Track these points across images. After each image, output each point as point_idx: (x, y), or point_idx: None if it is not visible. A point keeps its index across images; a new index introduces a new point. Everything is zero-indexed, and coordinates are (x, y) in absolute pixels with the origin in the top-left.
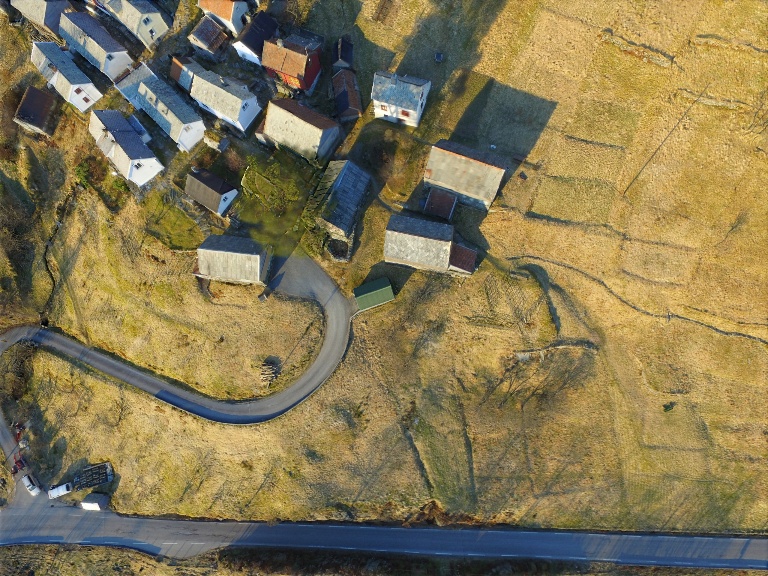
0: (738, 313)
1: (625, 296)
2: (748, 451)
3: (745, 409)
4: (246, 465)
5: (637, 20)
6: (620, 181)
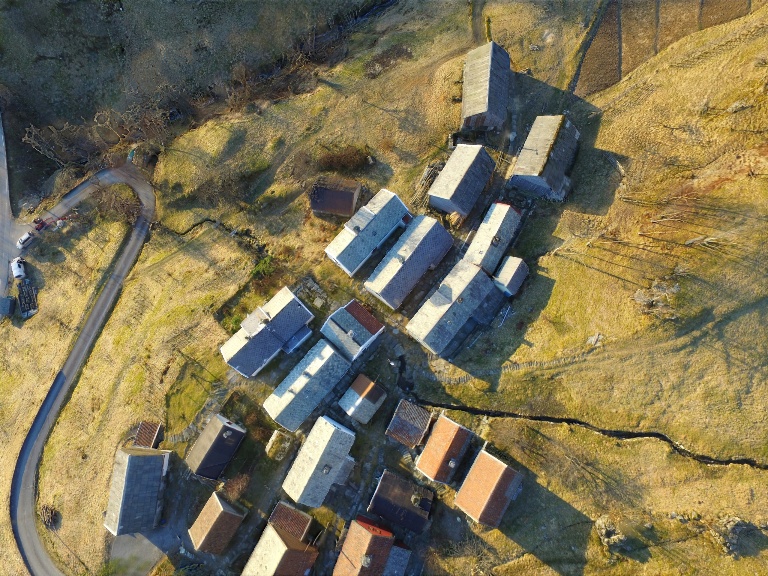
0: None
1: None
2: None
3: None
4: None
5: None
6: None
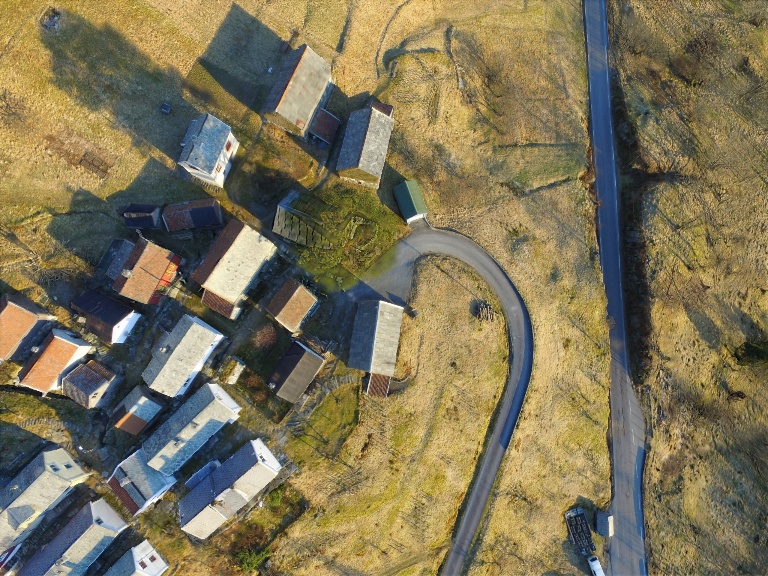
0: None
1: None
2: None
3: None
4: (566, 345)
5: None
6: None
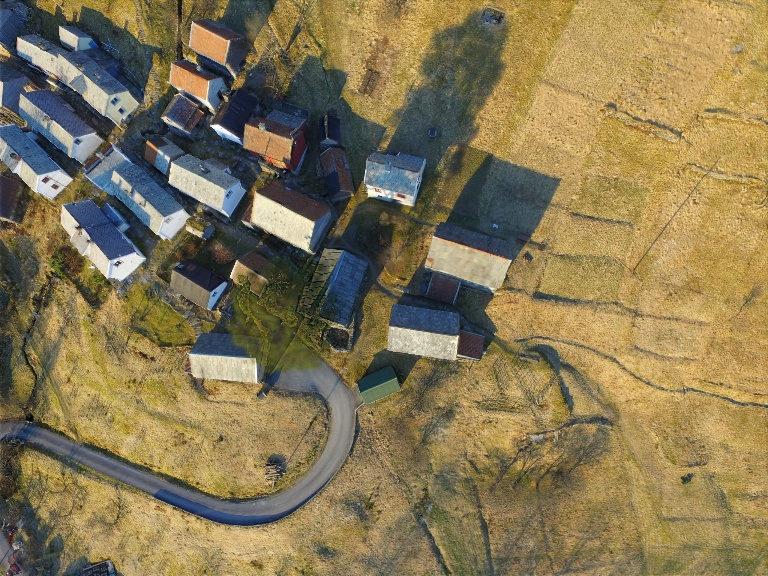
0: (754, 385)
1: (639, 372)
2: (767, 517)
3: (763, 476)
4: (255, 564)
5: (642, 95)
6: (629, 258)
